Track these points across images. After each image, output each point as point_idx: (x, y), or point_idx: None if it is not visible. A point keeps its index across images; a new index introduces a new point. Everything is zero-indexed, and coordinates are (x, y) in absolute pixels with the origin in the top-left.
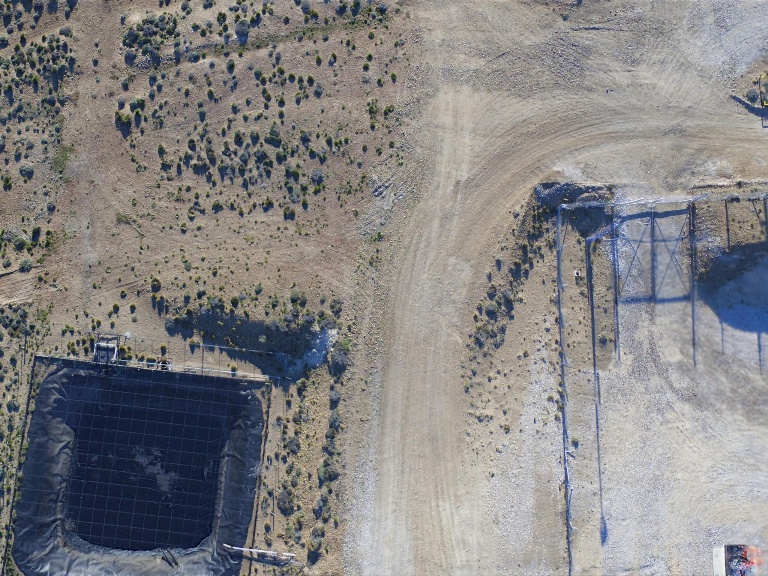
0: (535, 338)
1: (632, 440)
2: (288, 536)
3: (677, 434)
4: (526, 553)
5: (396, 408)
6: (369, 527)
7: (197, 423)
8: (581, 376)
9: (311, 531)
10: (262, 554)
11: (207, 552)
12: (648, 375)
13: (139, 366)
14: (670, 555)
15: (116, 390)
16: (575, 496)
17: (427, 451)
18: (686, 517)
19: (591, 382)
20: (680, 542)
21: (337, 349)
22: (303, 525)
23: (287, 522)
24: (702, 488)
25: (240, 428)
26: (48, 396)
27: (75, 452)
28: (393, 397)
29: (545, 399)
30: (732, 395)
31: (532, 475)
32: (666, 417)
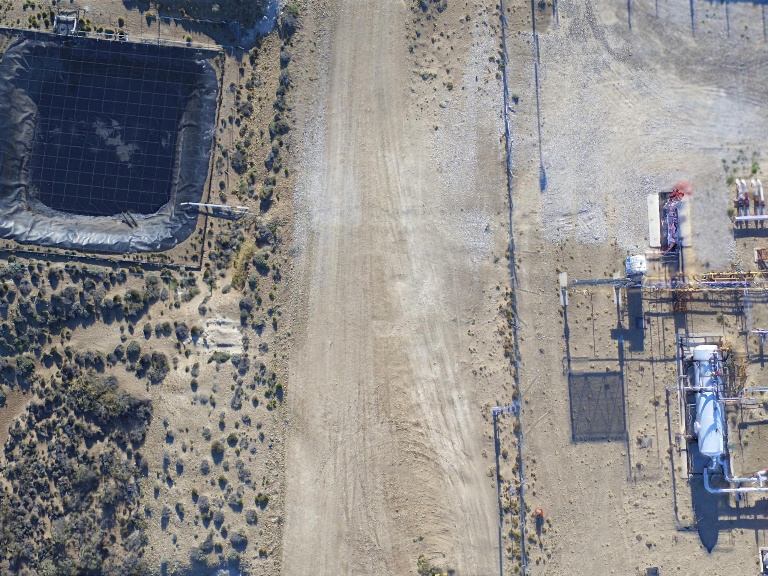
0: (477, 3)
1: (570, 96)
2: (242, 192)
3: (613, 91)
4: (469, 199)
5: (344, 67)
6: (318, 177)
7: (154, 90)
8: (521, 38)
9: (263, 182)
10: (217, 209)
11: (165, 216)
12: (585, 37)
13: (98, 37)
14: (607, 201)
15: (76, 60)
16: (515, 147)
17: (373, 106)
18: (622, 167)
19: (530, 43)
20: (616, 189)
21: (286, 12)
22: (256, 180)
23: (241, 180)
24: (637, 140)
25: (196, 97)
26: (10, 65)
27: (37, 117)
28: (341, 57)
29: (486, 59)
30: (666, 56)
31: (474, 128)
32: (602, 76)
